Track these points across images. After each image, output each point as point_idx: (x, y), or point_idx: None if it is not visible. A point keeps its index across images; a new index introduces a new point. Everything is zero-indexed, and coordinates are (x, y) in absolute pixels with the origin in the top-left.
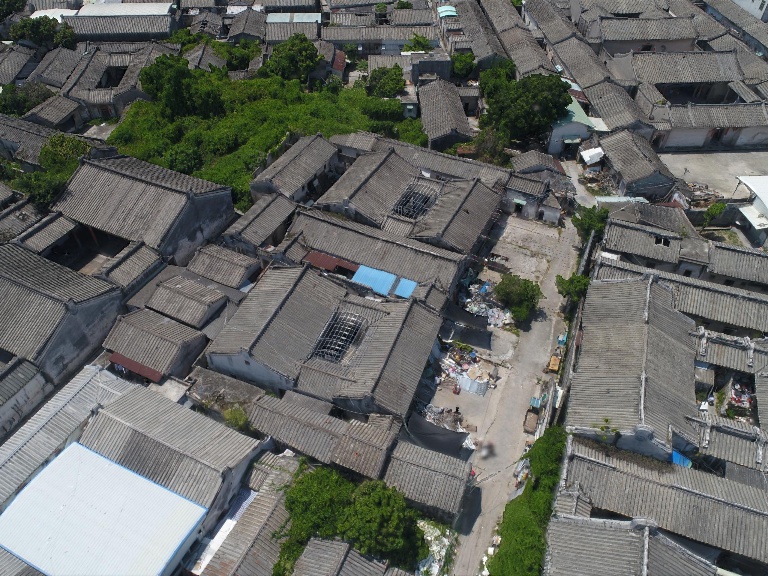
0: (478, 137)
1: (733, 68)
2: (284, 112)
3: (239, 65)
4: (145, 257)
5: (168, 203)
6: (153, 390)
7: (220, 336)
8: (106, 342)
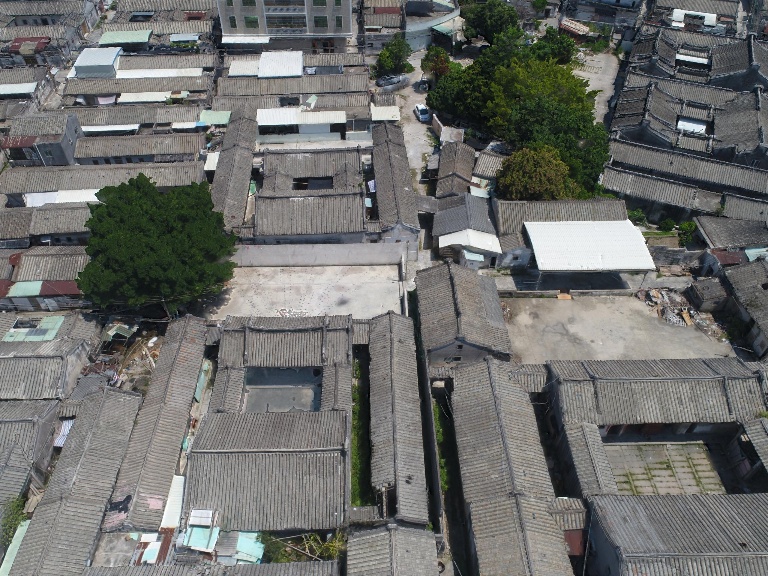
0: None
1: (617, 520)
2: None
3: None
4: None
5: None
6: None
7: None
8: None
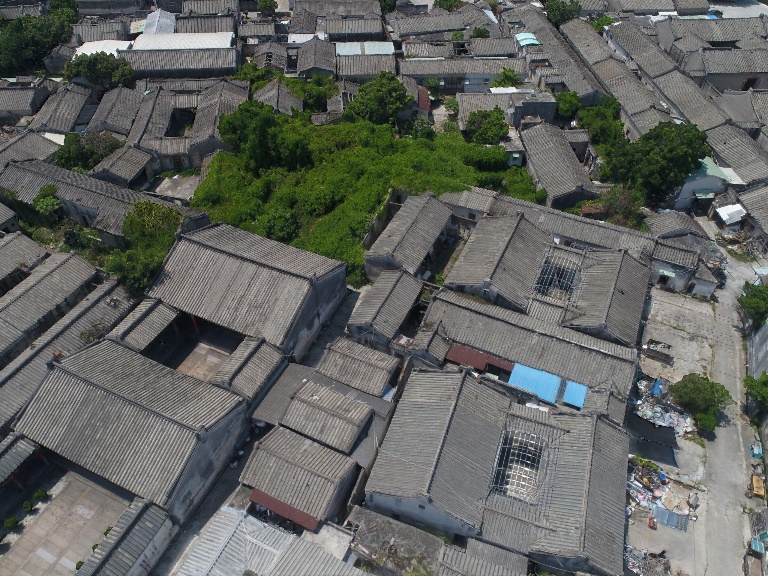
0: (609, 196)
1: None
2: (380, 163)
3: (314, 104)
4: (267, 357)
5: (286, 289)
6: (308, 540)
7: (377, 466)
8: (243, 476)
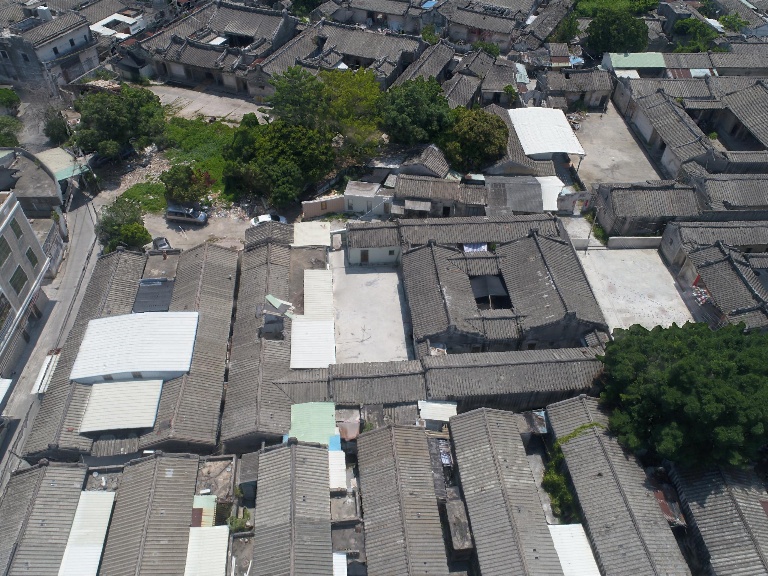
0: None
1: None
2: None
3: None
4: None
5: None
6: None
7: None
8: None
